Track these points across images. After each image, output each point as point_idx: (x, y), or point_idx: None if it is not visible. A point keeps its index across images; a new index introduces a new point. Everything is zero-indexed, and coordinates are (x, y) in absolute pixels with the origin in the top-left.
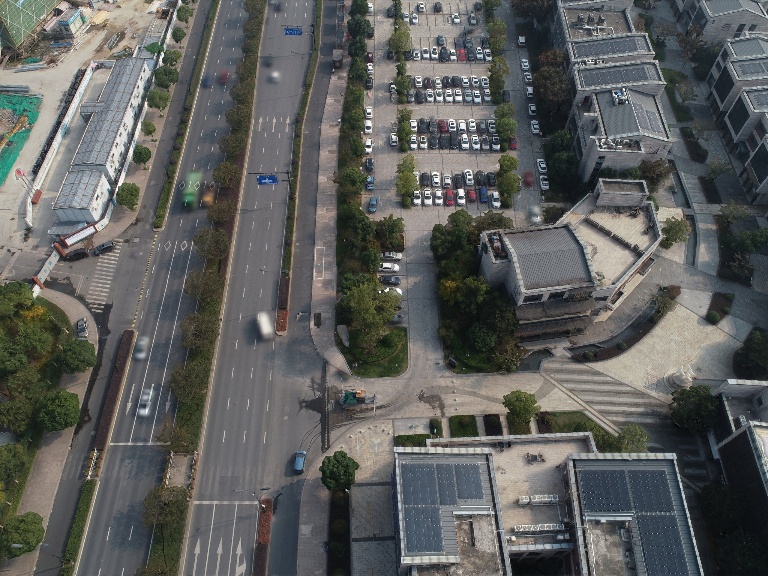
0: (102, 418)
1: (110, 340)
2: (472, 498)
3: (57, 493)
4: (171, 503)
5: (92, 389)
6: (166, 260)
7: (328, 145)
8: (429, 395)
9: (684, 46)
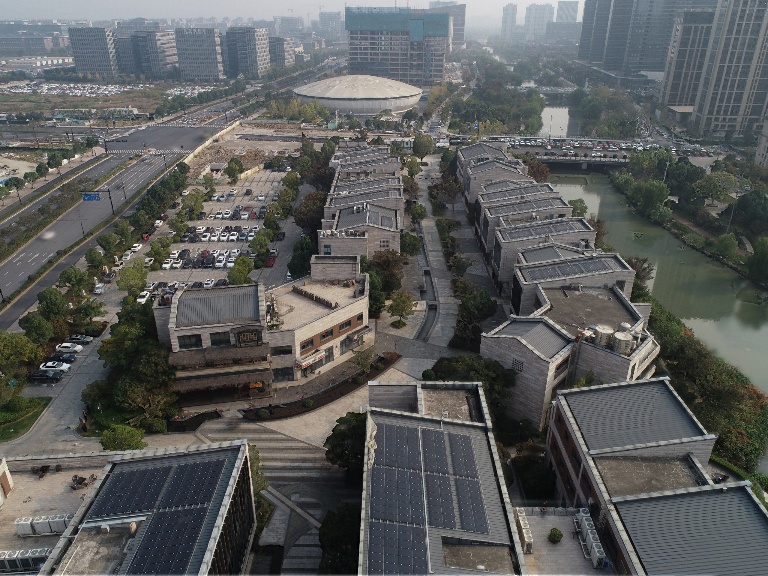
0: None
1: None
2: None
3: None
4: None
5: None
6: None
7: None
8: None
9: (448, 194)
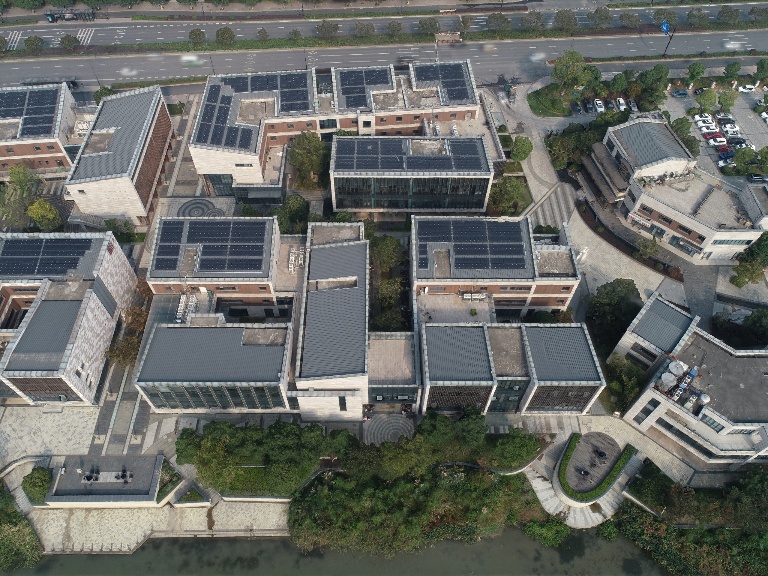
0: (473, 8)
1: (520, 5)
2: (448, 95)
3: (432, 6)
4: (431, 24)
5: (489, 5)
6: (584, 14)
7: None
8: (523, 127)
9: None
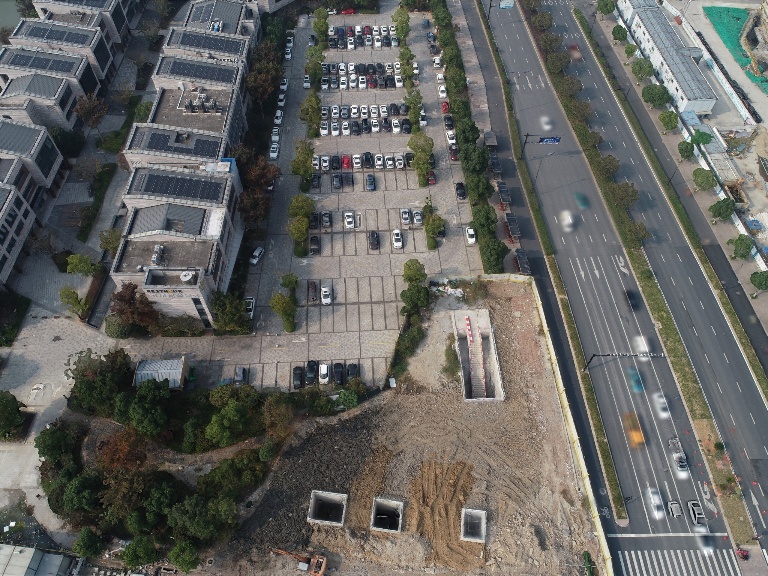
0: None
1: None
2: None
3: None
4: None
5: None
6: None
7: (473, 66)
8: None
9: None
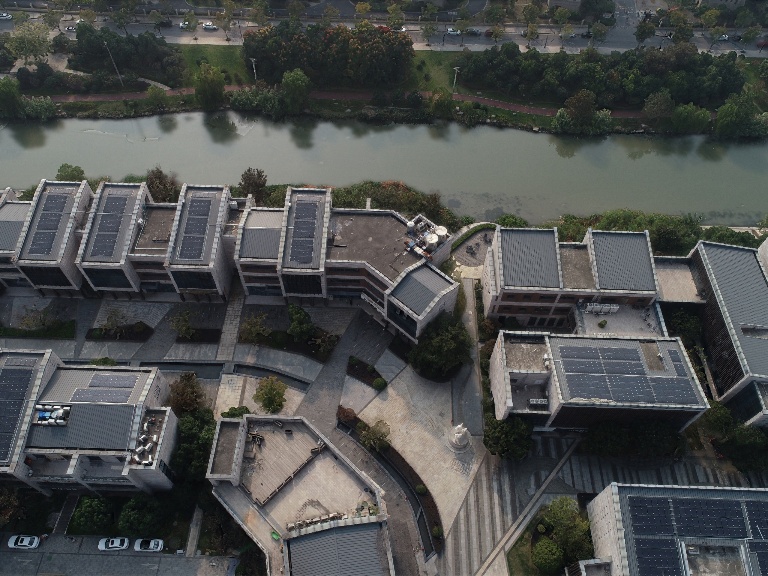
0: None
1: None
2: None
3: None
4: None
5: None
6: None
7: None
8: None
9: None
